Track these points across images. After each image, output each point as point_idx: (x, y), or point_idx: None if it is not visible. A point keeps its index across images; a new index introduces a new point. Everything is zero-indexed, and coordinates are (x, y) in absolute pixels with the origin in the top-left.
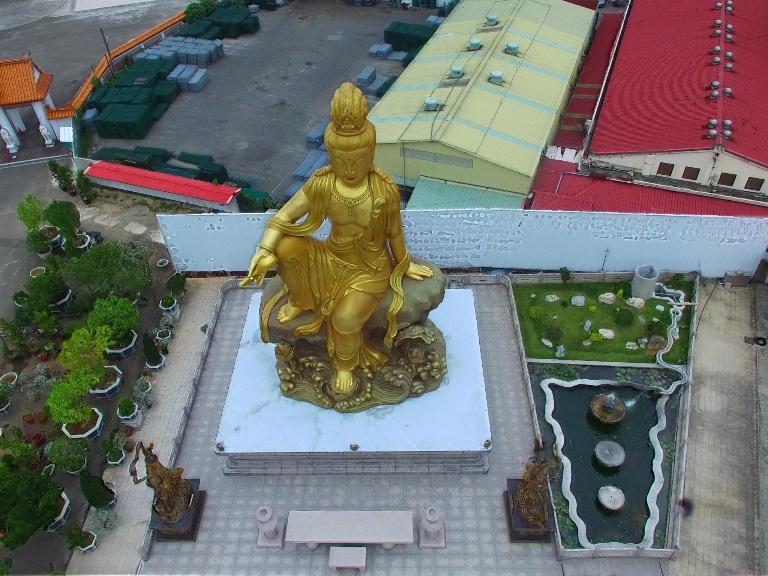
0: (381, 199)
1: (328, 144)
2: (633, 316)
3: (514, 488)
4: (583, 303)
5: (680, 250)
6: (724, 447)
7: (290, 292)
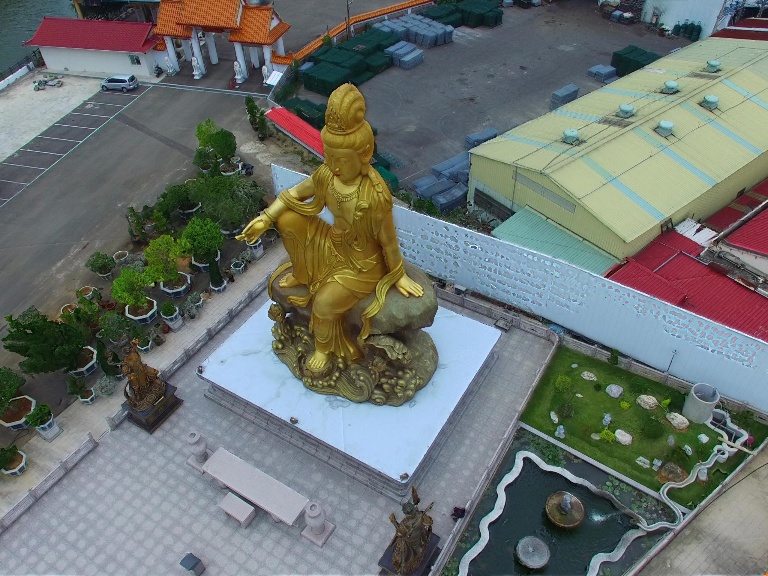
0: (364, 203)
1: None
2: (663, 432)
3: None
4: (617, 395)
5: (766, 386)
6: None
7: None
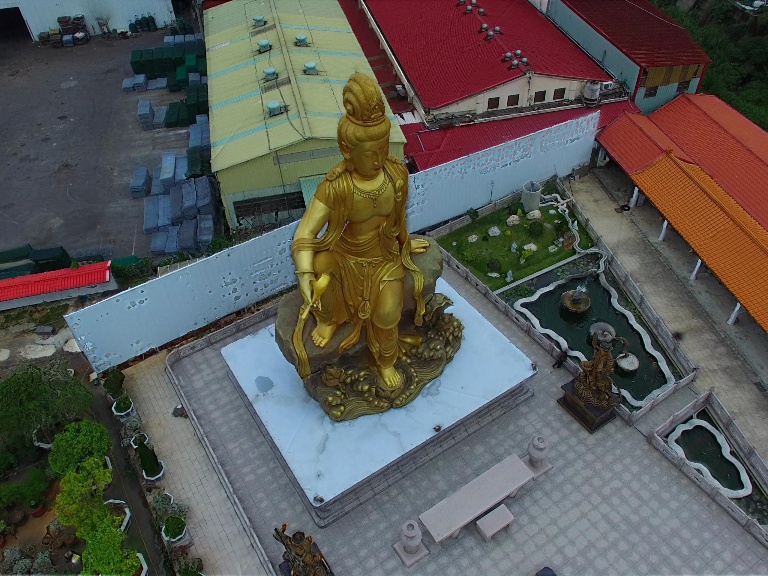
0: (401, 181)
1: (355, 140)
2: None
3: (573, 390)
4: (499, 232)
5: (541, 162)
6: (662, 289)
7: (323, 312)
